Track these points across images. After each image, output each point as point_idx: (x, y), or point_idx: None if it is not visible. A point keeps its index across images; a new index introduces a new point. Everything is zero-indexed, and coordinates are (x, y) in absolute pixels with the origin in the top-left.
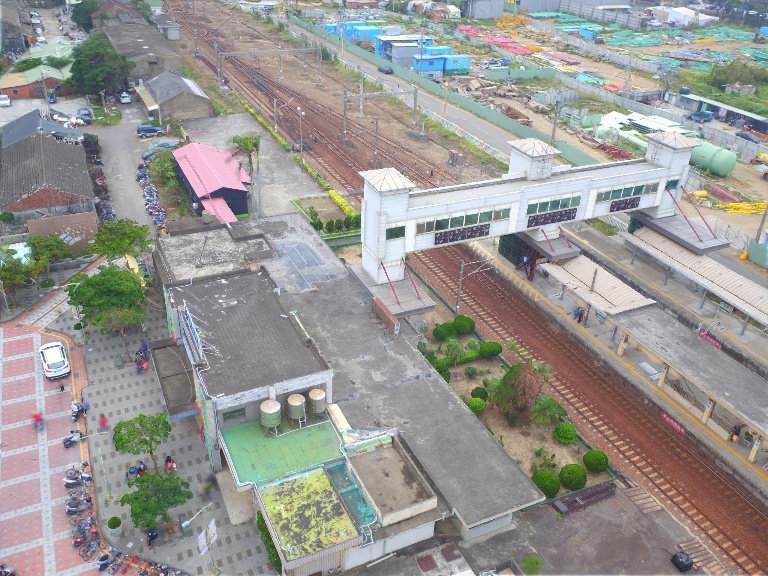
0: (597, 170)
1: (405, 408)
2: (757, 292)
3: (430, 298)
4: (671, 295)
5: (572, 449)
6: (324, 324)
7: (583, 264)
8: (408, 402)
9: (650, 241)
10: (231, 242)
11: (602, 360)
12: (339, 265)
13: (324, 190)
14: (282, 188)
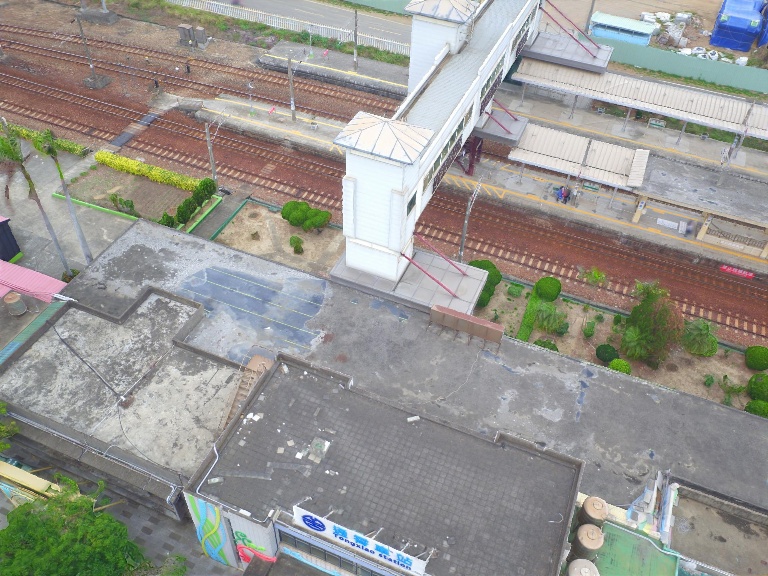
0: (489, 10)
1: (627, 436)
2: (684, 96)
3: (473, 267)
4: (589, 127)
5: (717, 356)
6: (404, 381)
7: (538, 135)
8: (619, 426)
9: (543, 75)
10: (115, 328)
11: (625, 237)
12: (302, 277)
13: (80, 156)
14: (12, 180)
